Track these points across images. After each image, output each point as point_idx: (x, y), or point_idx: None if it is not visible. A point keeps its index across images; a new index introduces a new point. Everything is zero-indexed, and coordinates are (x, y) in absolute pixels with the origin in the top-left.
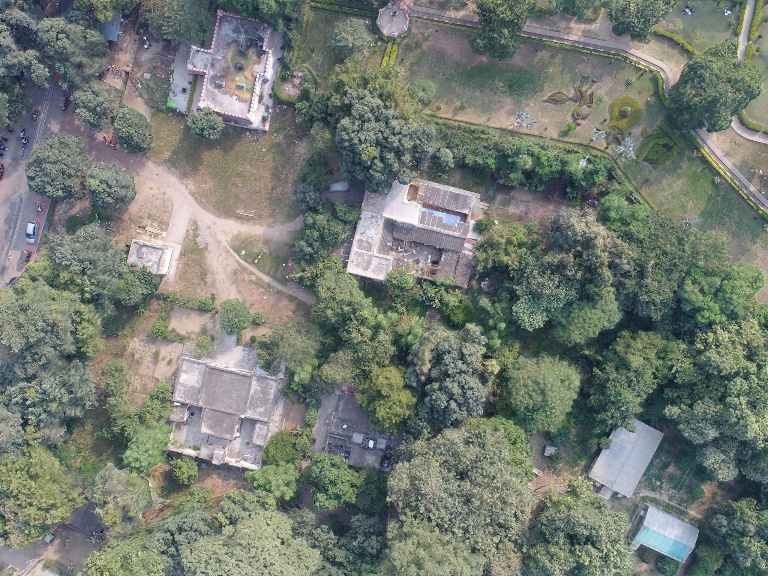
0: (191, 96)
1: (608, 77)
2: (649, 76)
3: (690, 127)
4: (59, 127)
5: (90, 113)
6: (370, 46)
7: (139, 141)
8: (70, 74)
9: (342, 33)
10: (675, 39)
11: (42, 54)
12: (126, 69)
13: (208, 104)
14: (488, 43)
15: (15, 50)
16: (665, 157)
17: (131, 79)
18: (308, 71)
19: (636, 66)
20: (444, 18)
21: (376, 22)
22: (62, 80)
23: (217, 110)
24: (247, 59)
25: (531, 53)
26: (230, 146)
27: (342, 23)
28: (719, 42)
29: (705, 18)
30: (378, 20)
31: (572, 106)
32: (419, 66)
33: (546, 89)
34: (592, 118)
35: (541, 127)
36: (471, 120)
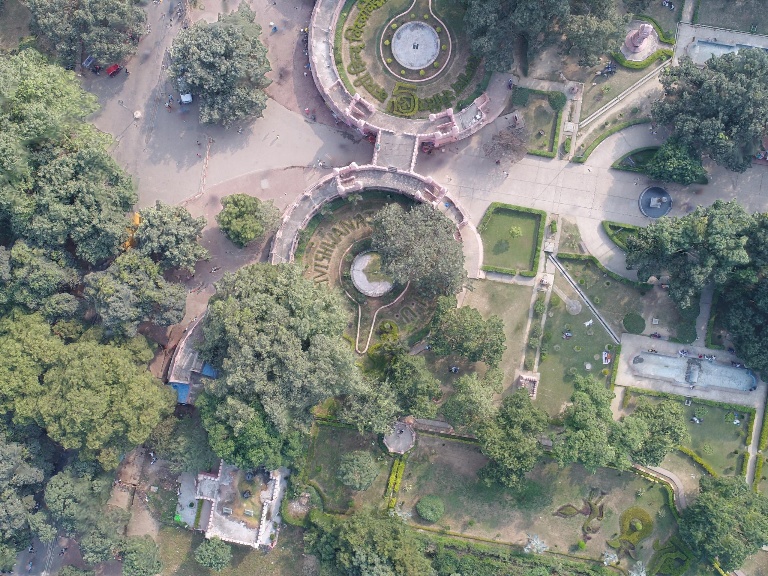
0: (198, 512)
1: (617, 488)
2: (659, 487)
3: (703, 561)
4: (67, 541)
5: (98, 555)
6: (377, 460)
7: (147, 575)
8: (77, 528)
9: (349, 474)
10: (684, 451)
11: (49, 513)
12: (133, 482)
13: (215, 531)
14: (496, 480)
15: (22, 512)
16: (678, 571)
17: (138, 492)
18: (315, 490)
19: (645, 478)
20: (450, 430)
21: (382, 441)
22: (69, 531)
23: (225, 538)
24: (254, 485)
25: (539, 465)
26: (238, 559)
27: (348, 455)
28: (728, 450)
29: (713, 426)
30: (384, 438)
31: (582, 519)
32: (426, 480)
33: (555, 502)
34: (602, 531)
35: (551, 541)
36: (480, 535)
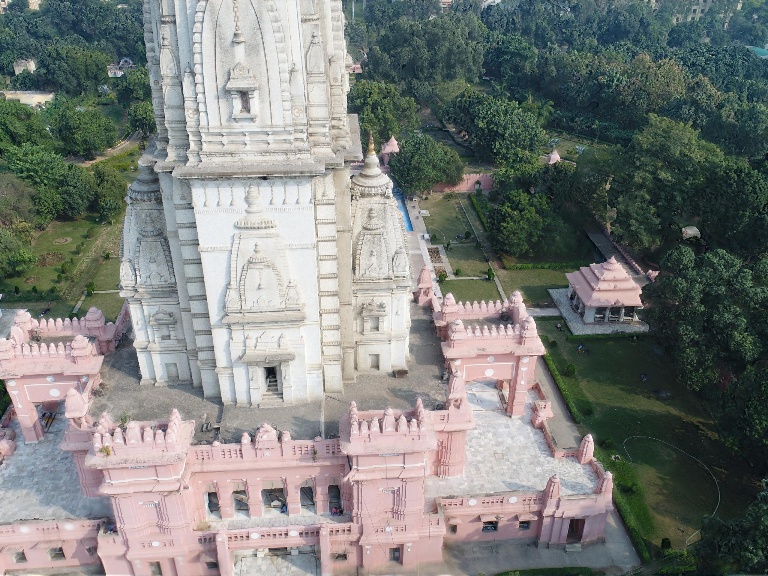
0: None
1: None
2: None
3: None
4: None
5: None
6: None
7: None
8: None
9: None
10: None
11: None
12: None
13: None
14: None
15: None
16: None
17: None
18: None
19: None
20: None
21: None
22: None
23: None
24: None
25: None
26: None
27: None
28: None
29: None
30: None
31: None
32: None
33: None
34: None
35: None
36: None
